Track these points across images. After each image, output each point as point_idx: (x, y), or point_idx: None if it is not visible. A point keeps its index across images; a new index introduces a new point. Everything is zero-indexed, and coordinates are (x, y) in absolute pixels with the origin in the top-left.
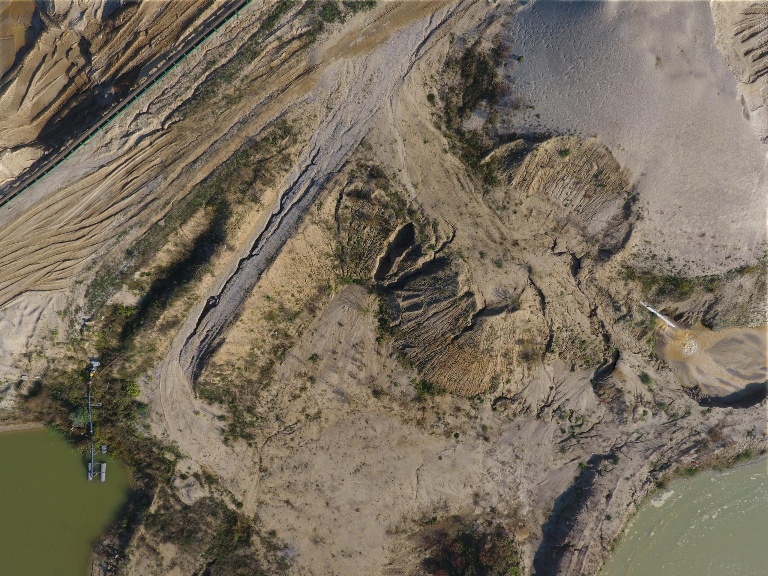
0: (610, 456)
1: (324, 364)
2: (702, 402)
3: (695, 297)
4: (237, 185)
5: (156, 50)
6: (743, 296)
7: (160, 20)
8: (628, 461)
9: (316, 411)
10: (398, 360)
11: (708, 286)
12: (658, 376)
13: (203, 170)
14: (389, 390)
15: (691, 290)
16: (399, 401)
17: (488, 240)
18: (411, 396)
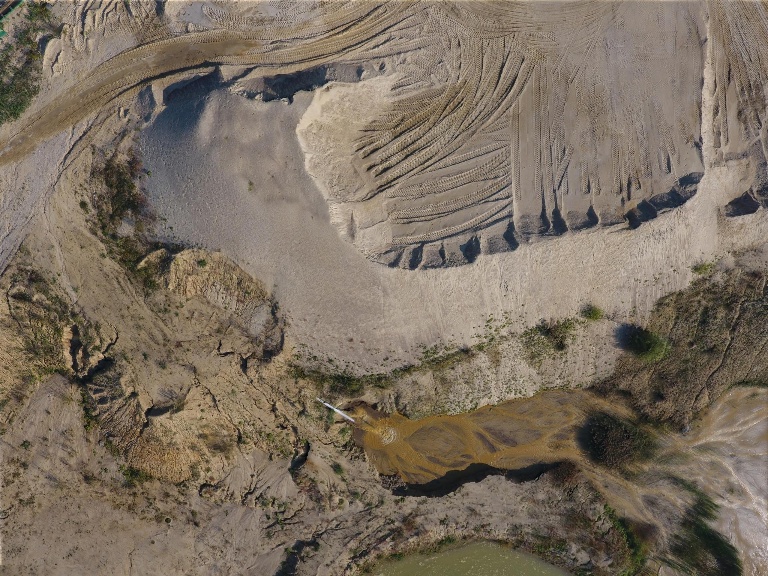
0: (312, 542)
1: (36, 450)
2: (398, 490)
3: (373, 392)
4: None
5: None
6: (424, 390)
7: None
8: (327, 548)
9: (29, 496)
10: (106, 447)
11: (377, 384)
12: (351, 466)
13: None
14: (100, 476)
15: (361, 388)
16: (110, 487)
17: (151, 342)
18: (121, 482)
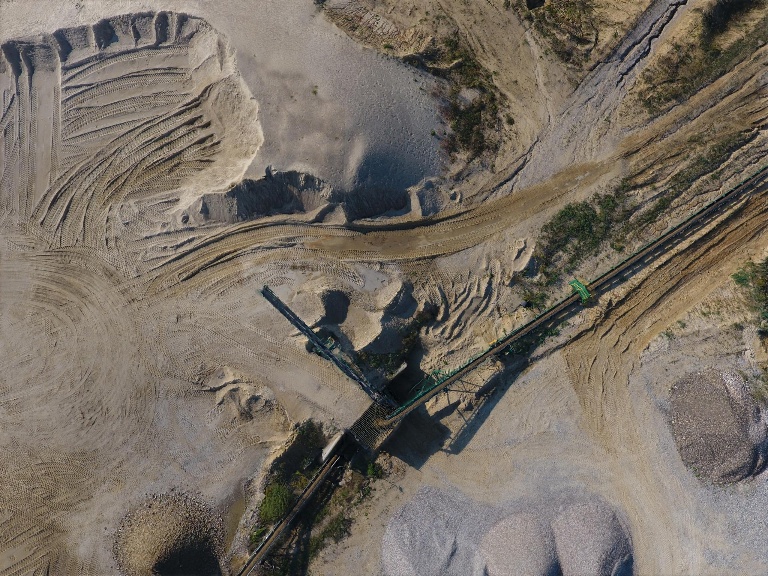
0: None
1: None
2: None
3: None
4: (693, 64)
5: (765, 199)
6: None
7: (761, 225)
8: None
9: None
10: None
11: None
12: None
13: (724, 83)
14: None
15: None
16: None
17: None
18: None
